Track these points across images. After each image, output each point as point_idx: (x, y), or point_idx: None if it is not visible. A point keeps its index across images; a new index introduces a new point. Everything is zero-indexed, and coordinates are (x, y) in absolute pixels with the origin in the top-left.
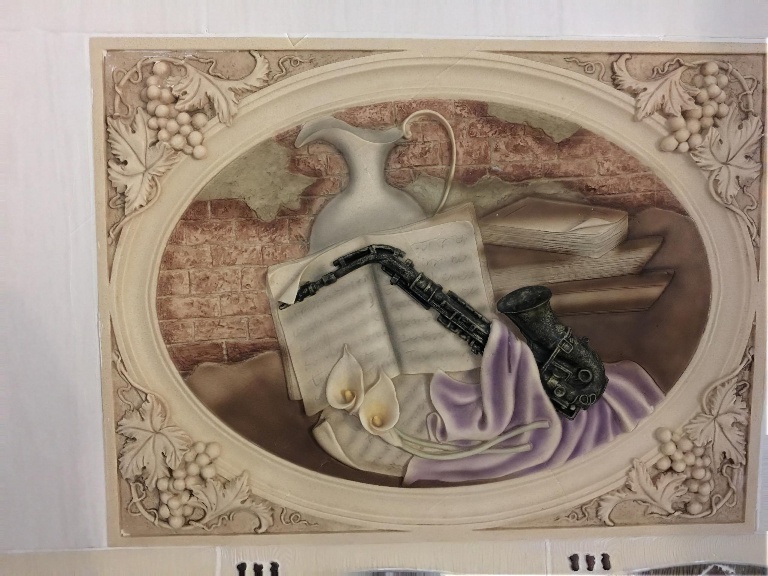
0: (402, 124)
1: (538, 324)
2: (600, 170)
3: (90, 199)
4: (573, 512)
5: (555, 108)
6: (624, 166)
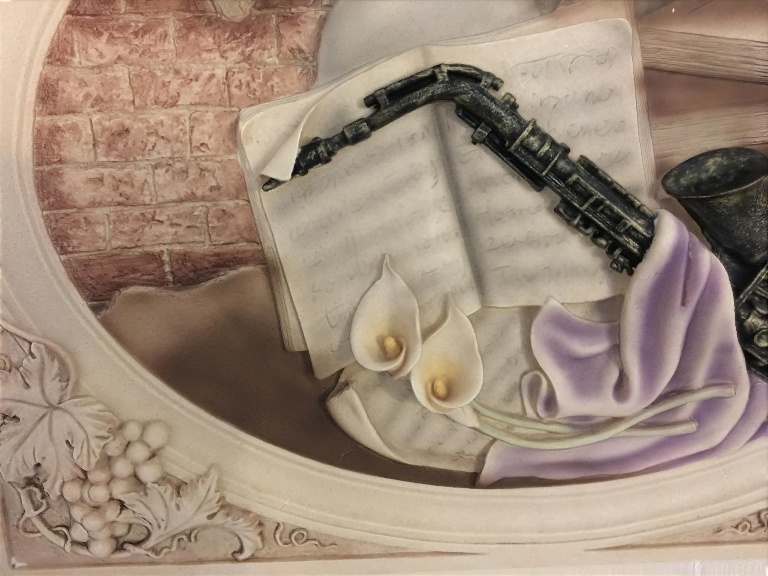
0: None
1: (742, 218)
2: None
3: None
4: (745, 520)
5: None
6: None
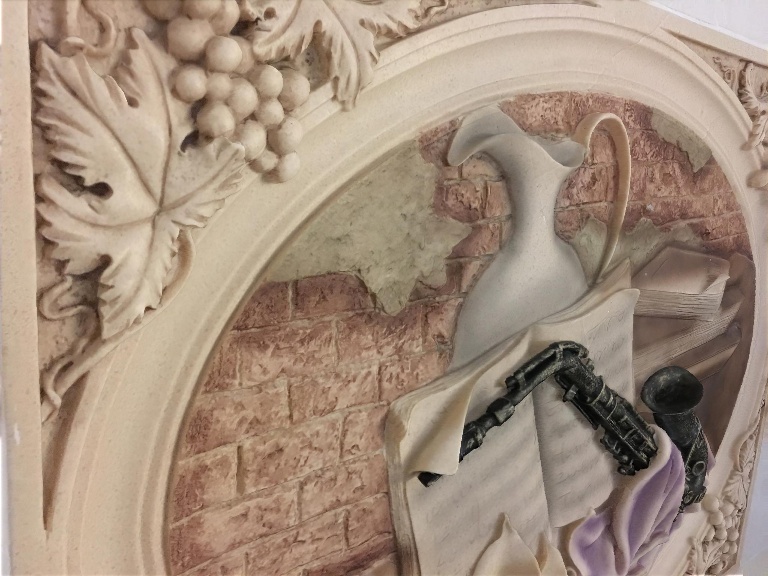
0: (576, 132)
1: (688, 421)
2: (715, 209)
3: None
4: None
5: (698, 125)
6: (727, 204)
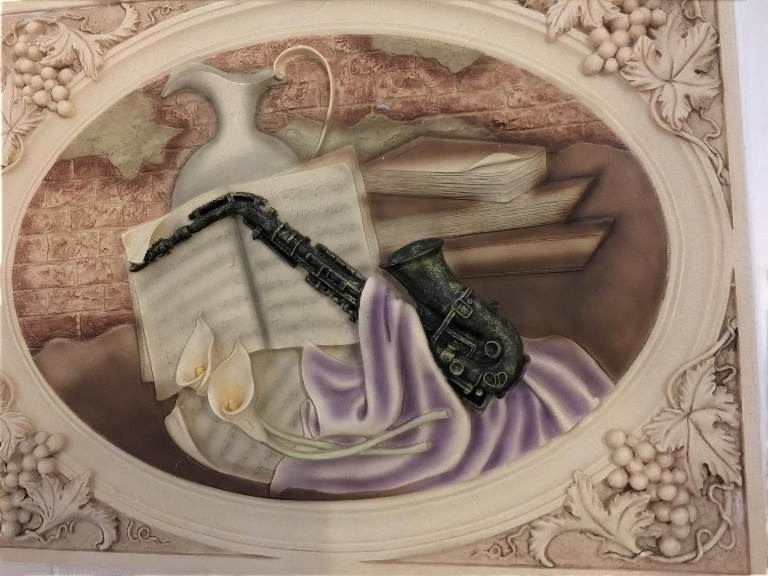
0: None
1: (425, 280)
2: (509, 101)
3: None
4: (495, 544)
5: (451, 35)
6: (540, 95)
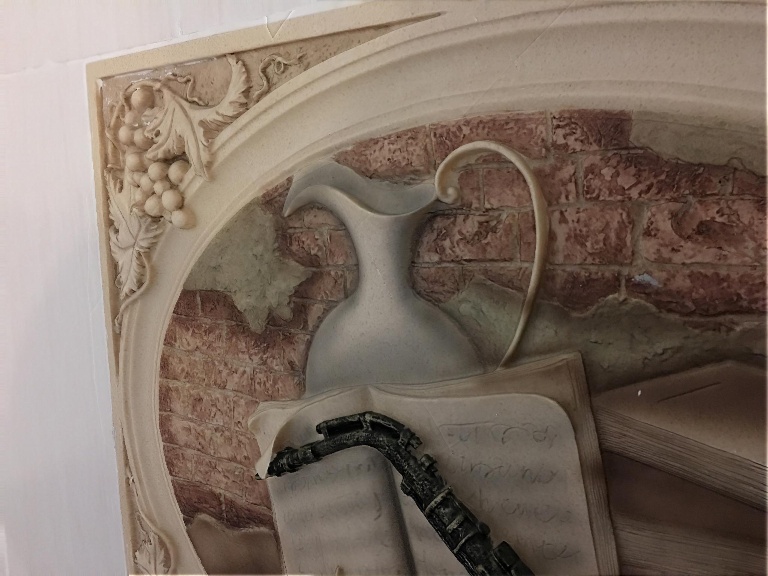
0: None
1: None
2: None
3: (100, 275)
4: None
5: None
6: None
